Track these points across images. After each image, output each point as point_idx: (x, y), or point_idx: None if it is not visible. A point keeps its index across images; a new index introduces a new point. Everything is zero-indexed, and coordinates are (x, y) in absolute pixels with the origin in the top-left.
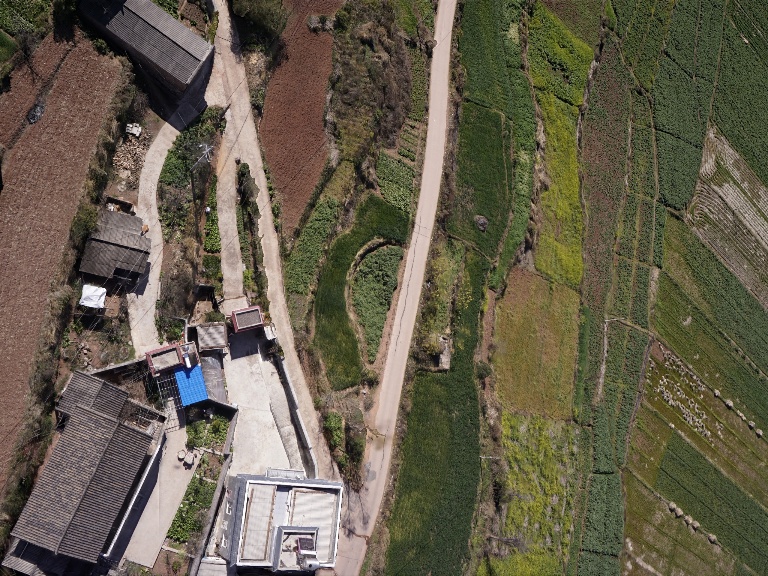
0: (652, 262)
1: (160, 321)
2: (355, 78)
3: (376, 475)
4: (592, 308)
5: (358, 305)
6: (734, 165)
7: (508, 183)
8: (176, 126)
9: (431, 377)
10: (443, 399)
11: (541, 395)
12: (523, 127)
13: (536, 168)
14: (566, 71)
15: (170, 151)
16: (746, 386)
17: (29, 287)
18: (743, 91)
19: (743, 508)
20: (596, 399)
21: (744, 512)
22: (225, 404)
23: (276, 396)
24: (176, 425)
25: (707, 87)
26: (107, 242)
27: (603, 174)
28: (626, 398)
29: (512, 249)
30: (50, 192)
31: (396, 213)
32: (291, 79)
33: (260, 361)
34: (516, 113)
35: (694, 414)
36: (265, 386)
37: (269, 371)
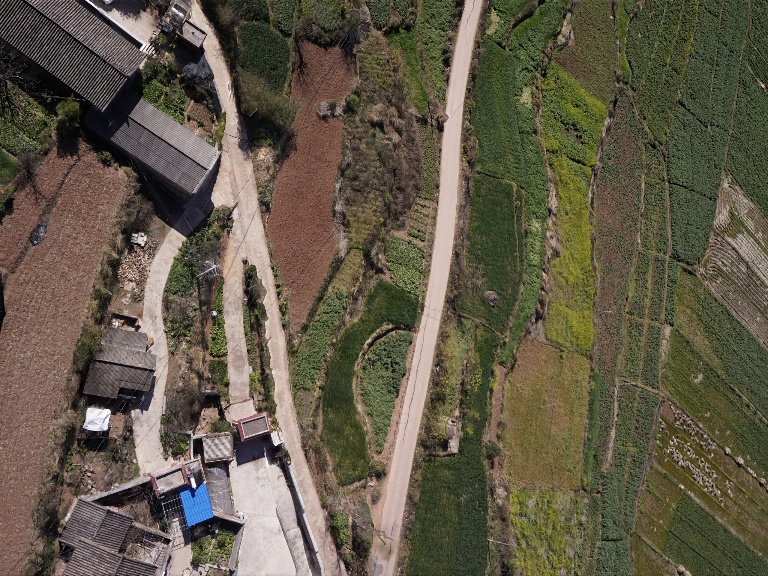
0: (664, 320)
1: (165, 437)
2: (365, 163)
3: (383, 569)
4: (602, 372)
5: (366, 394)
6: (748, 215)
7: (519, 255)
8: (182, 231)
9: (439, 462)
10: (451, 484)
11: (550, 467)
12: (535, 195)
13: (548, 235)
14: (579, 131)
15: (176, 258)
16: (757, 442)
17: (32, 416)
18: (759, 138)
19: (752, 567)
20: (605, 465)
21: (753, 571)
22: (231, 520)
23: (282, 500)
24: (181, 542)
25: (722, 136)
26: (111, 363)
27: (615, 233)
28: (636, 462)
29: (522, 322)
30: (53, 315)
31: (405, 297)
32: (300, 170)
33: (266, 465)
34: (528, 181)
35: (704, 474)
36: (271, 491)
37: (275, 475)
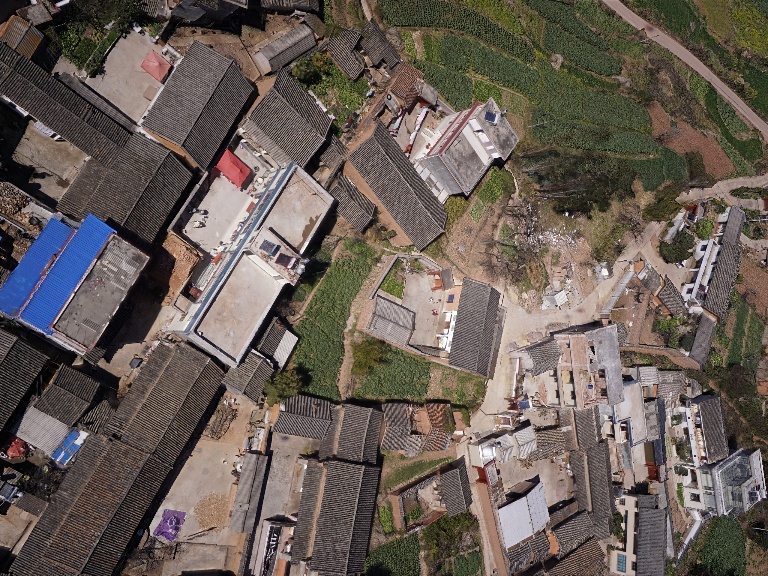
0: None
1: None
2: None
3: None
4: None
5: None
6: None
7: None
8: None
9: None
10: None
11: (723, 7)
12: None
13: None
14: None
15: None
16: None
17: None
18: None
19: None
20: None
21: None
22: None
23: None
24: None
25: None
26: None
27: None
28: None
29: (693, 4)
30: None
31: None
32: None
33: None
34: None
35: None
36: None
37: None
